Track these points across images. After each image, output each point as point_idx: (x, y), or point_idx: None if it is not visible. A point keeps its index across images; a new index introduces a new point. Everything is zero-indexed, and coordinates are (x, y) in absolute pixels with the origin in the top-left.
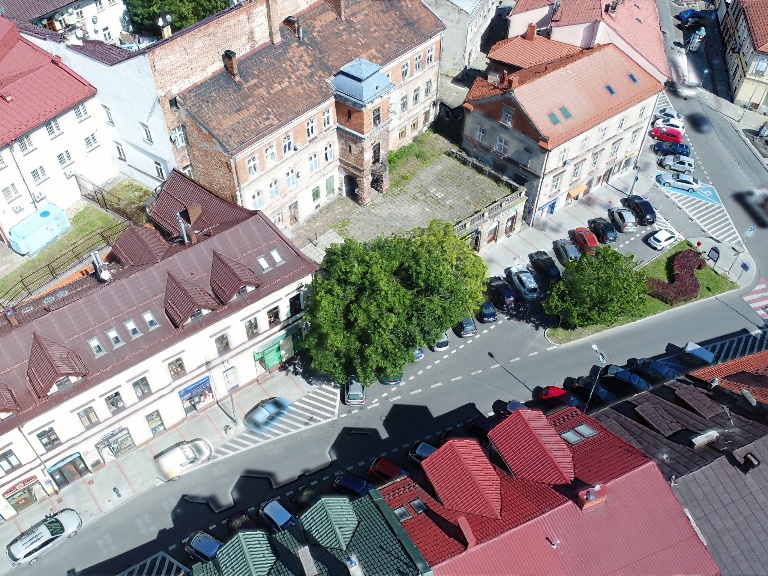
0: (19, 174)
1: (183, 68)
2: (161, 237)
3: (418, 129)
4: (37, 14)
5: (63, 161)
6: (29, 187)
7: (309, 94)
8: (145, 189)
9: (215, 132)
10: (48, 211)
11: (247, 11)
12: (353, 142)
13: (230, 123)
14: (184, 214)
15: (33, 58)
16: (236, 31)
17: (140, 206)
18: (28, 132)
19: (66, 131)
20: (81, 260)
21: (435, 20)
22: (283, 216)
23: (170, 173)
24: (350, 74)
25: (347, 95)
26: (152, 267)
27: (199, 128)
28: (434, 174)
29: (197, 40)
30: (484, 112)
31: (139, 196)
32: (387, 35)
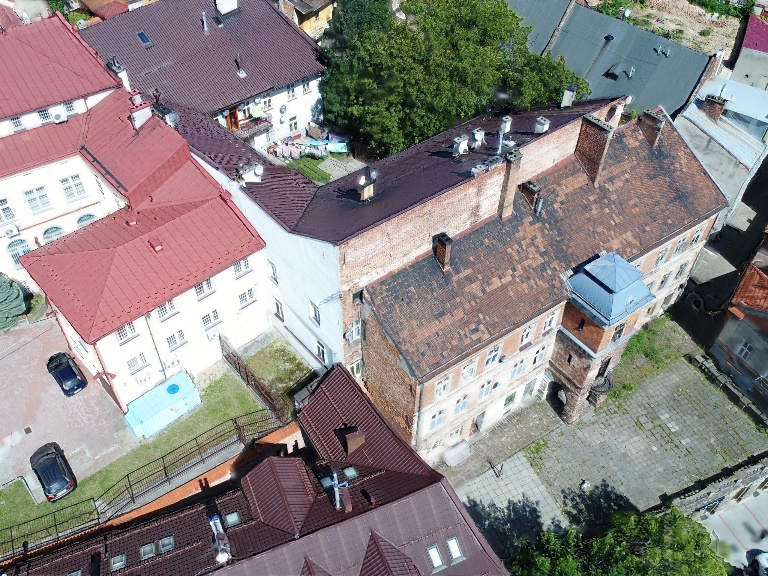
0: (151, 342)
1: (380, 256)
2: (306, 476)
3: (652, 314)
4: (219, 105)
5: (208, 322)
6: (161, 355)
7: (536, 296)
8: (299, 360)
9: (404, 347)
10: (177, 385)
11: (479, 182)
12: (577, 354)
13: (426, 334)
14: (341, 434)
15: (199, 187)
16: (458, 207)
17: (288, 387)
18: (171, 297)
19: (219, 289)
20: (203, 457)
21: (716, 193)
22: (463, 429)
23: (333, 363)
24: (598, 279)
25: (587, 303)
26: (286, 547)
27: (384, 335)
28: (667, 389)
29: (406, 222)
30: (759, 328)
31: (290, 370)
32: (650, 212)
